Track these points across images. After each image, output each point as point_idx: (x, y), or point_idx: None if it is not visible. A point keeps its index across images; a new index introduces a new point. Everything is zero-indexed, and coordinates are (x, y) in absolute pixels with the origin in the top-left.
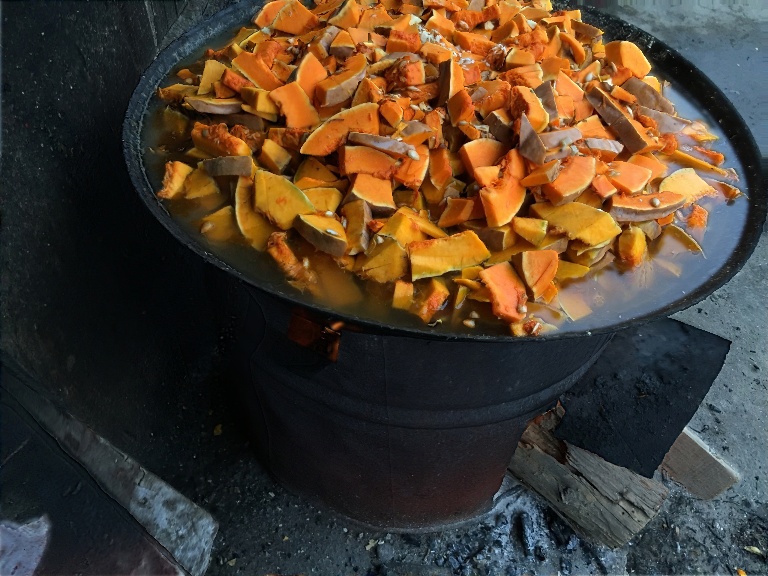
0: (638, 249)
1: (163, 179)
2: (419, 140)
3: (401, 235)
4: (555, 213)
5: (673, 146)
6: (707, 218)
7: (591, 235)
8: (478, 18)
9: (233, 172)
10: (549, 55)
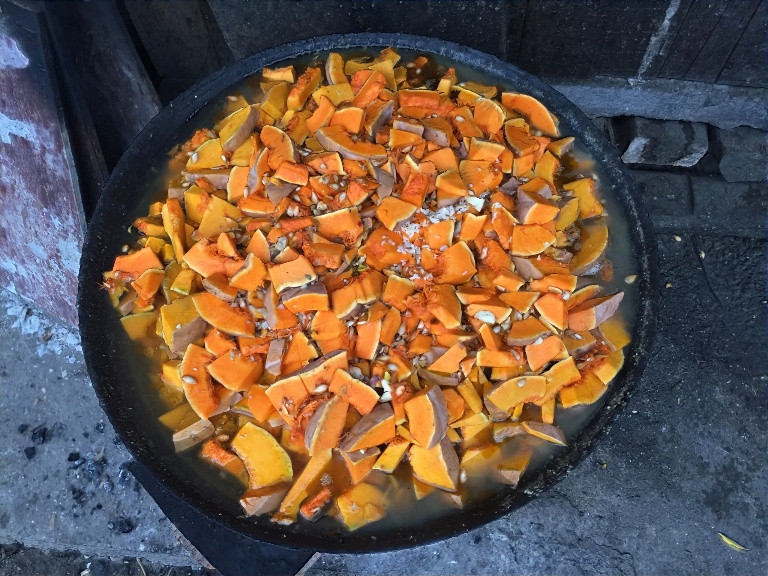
0: (171, 376)
1: (279, 68)
2: None
3: (189, 198)
4: None
5: None
6: None
7: (163, 322)
8: (492, 264)
9: None
10: (438, 335)
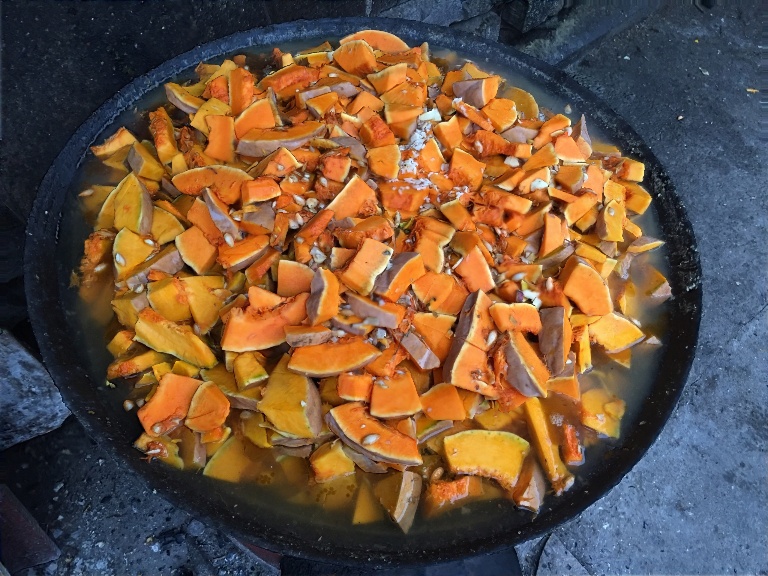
0: (330, 467)
1: (108, 137)
2: (260, 230)
3: (158, 297)
4: (283, 375)
5: (507, 405)
6: (466, 500)
7: (276, 418)
8: (496, 148)
9: (131, 163)
10: None
